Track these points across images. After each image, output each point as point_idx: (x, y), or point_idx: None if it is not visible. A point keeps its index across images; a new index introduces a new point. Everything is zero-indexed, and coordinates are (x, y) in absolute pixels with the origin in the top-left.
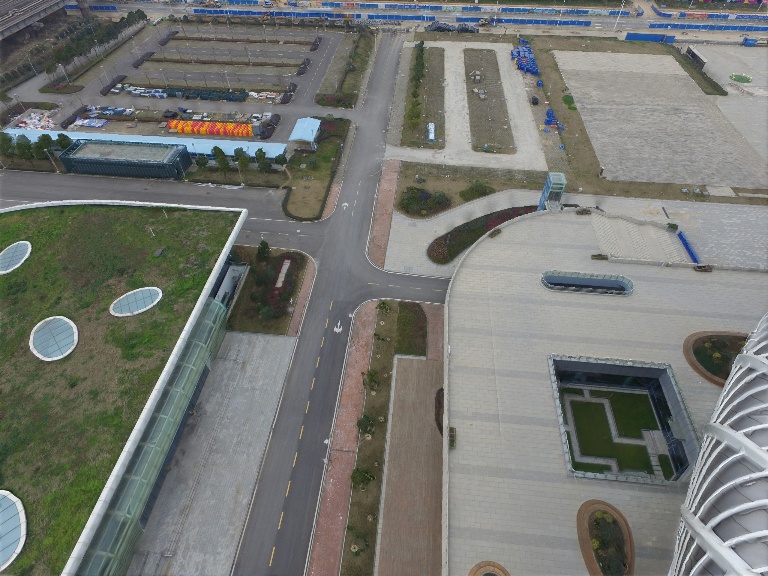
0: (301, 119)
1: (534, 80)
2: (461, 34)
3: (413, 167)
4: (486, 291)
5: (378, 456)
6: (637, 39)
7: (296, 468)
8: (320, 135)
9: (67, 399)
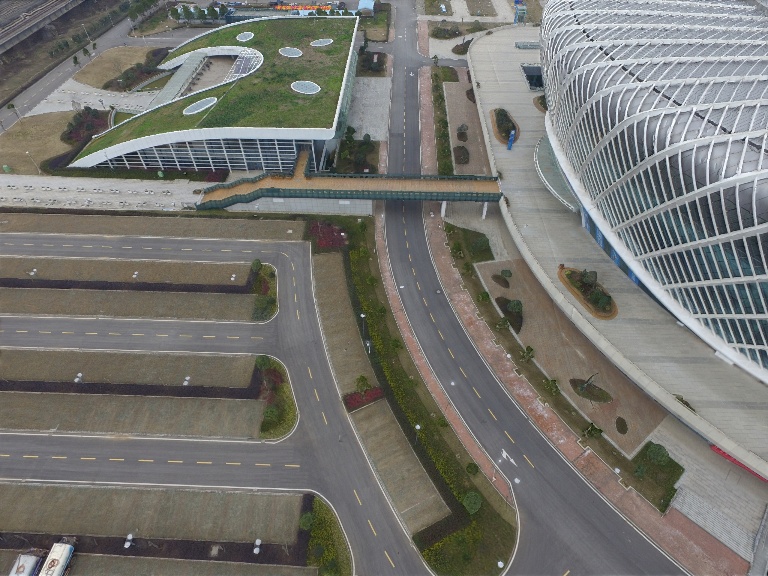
0: (362, 0)
1: None
2: None
3: (436, 23)
4: (487, 50)
5: (443, 106)
6: None
7: (406, 109)
8: (374, 10)
9: (310, 64)
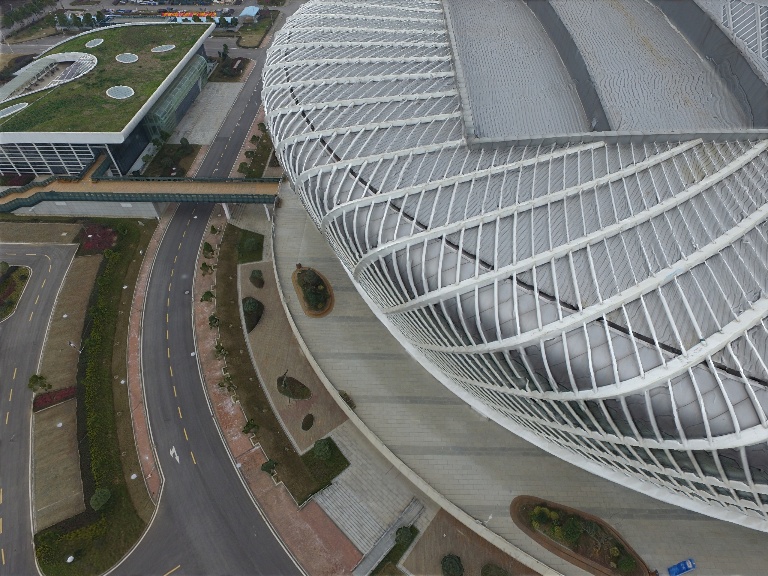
0: (247, 7)
1: None
2: None
3: None
4: None
5: None
6: None
7: (244, 114)
8: (260, 16)
9: (139, 70)
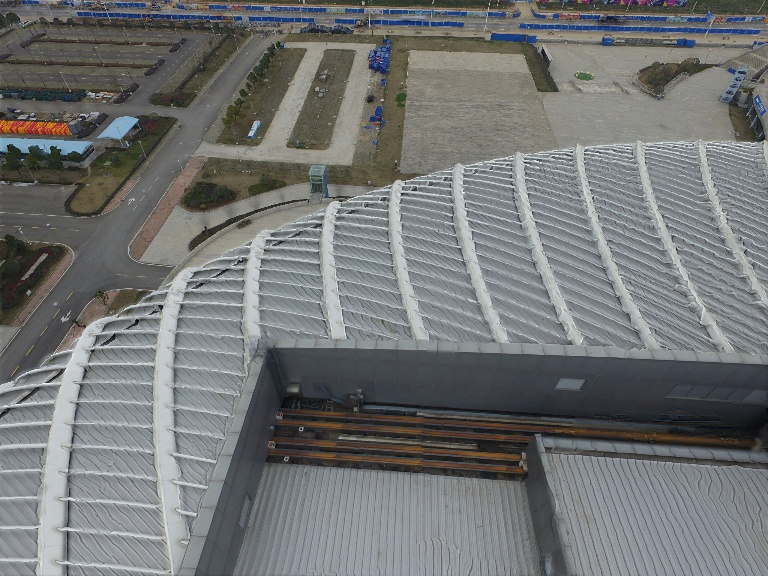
0: (119, 118)
1: (380, 79)
2: (330, 35)
3: (219, 163)
4: None
5: None
6: (502, 39)
7: None
8: (137, 133)
9: None
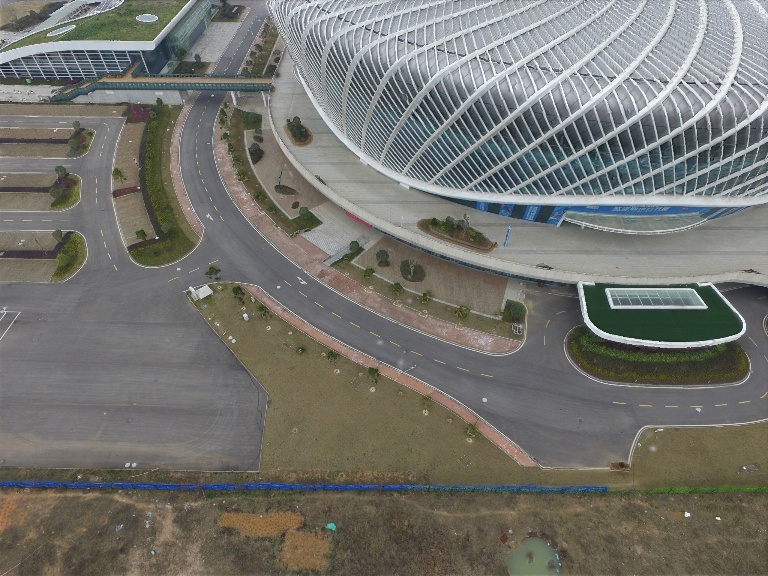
0: None
1: None
2: None
3: None
4: None
5: (273, 41)
6: None
7: (243, 43)
8: None
9: (159, 4)
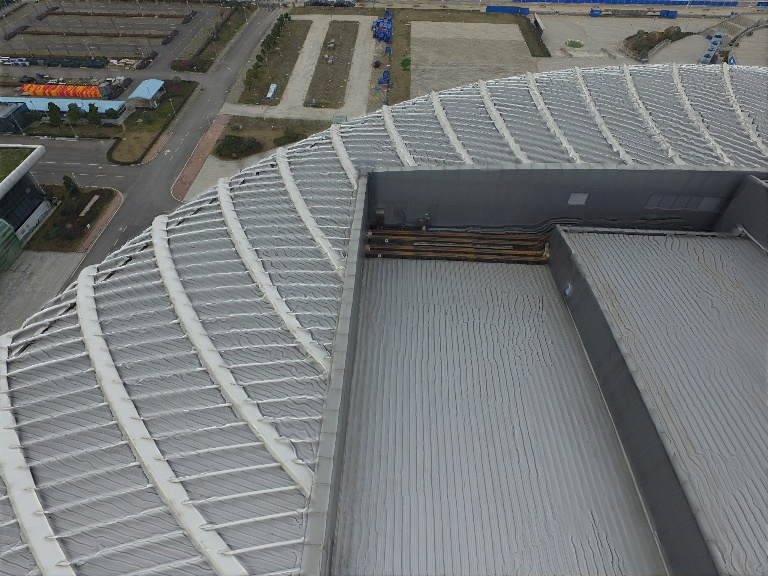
0: (146, 80)
1: (385, 47)
2: (333, 8)
3: (243, 120)
4: None
5: None
6: (496, 11)
7: None
8: (164, 95)
9: None
